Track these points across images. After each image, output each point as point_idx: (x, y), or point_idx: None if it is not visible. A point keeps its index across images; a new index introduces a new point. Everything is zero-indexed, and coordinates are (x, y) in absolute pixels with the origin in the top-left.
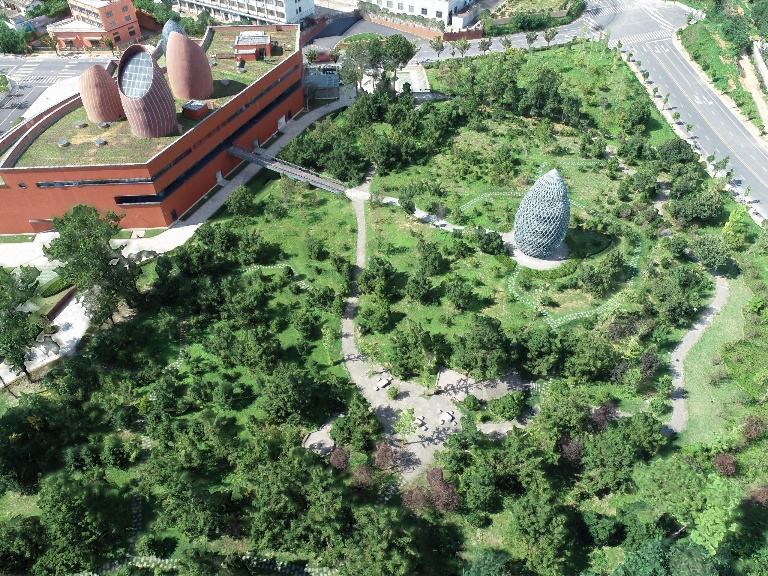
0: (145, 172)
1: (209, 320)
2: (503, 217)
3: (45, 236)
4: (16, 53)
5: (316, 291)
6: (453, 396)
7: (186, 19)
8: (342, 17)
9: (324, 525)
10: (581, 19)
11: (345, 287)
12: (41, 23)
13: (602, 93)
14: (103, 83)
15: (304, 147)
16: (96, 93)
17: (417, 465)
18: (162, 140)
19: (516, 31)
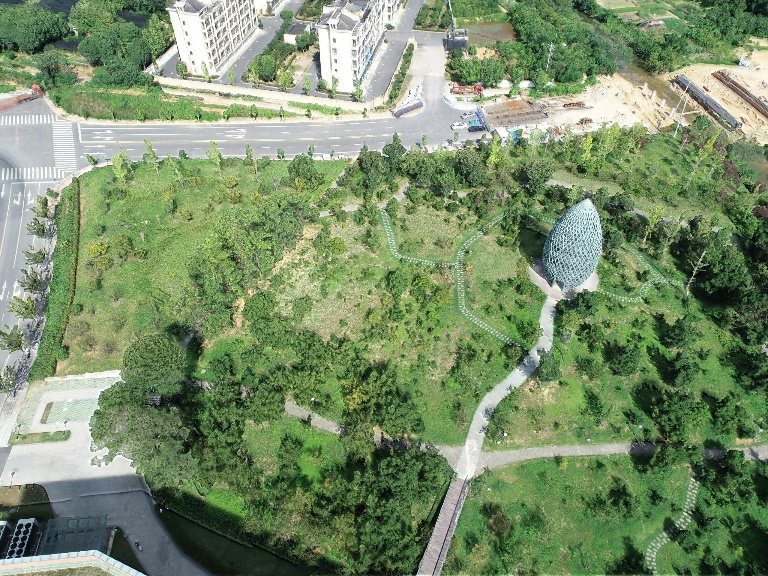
0: None
1: None
2: (513, 298)
3: None
4: None
5: None
6: None
7: None
8: None
9: None
10: None
11: None
12: None
13: (237, 188)
14: None
15: None
16: None
17: None
18: None
19: None
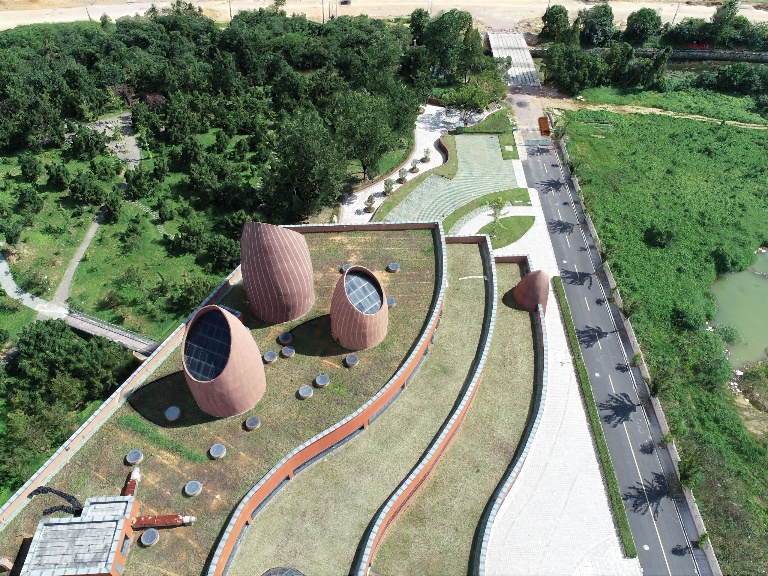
0: None
1: None
2: None
3: None
4: None
5: None
6: None
7: None
8: None
9: None
10: None
11: None
12: None
13: None
14: None
15: None
16: None
17: None
18: None
19: None
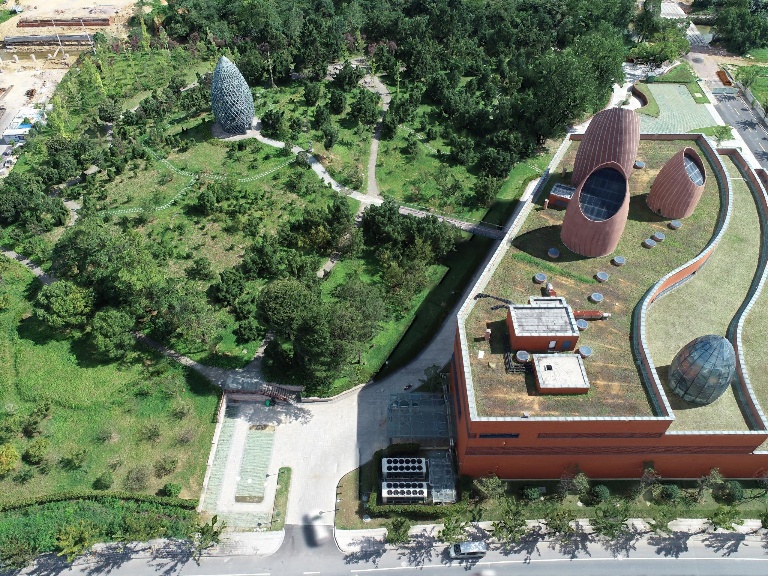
0: None
1: None
2: None
3: None
4: None
5: None
6: None
7: None
8: None
9: None
10: None
11: None
12: None
13: None
14: None
15: None
16: None
17: None
18: None
19: None
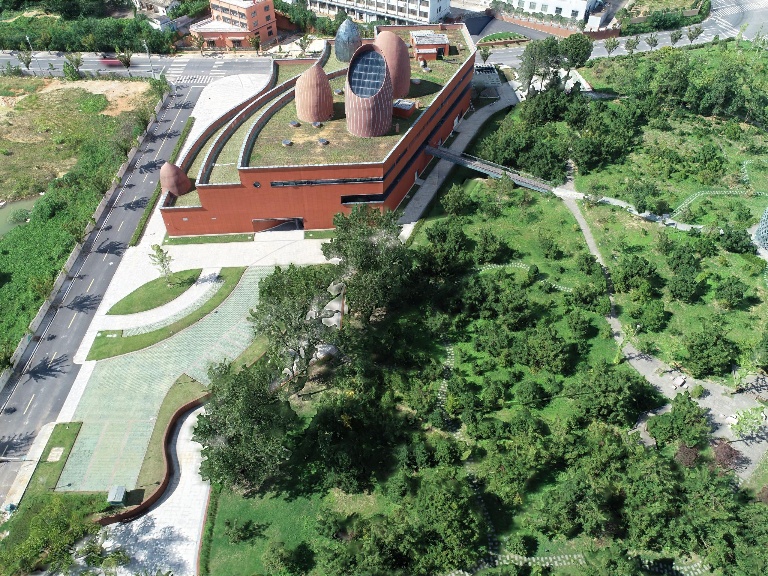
0: (379, 171)
1: (465, 319)
2: (729, 216)
3: (264, 235)
4: (160, 53)
5: (585, 290)
6: (758, 394)
7: (323, 19)
8: (474, 16)
9: (716, 523)
10: (711, 18)
11: (604, 286)
12: (182, 23)
13: None
14: (322, 82)
15: (502, 146)
16: (315, 92)
17: (748, 463)
18: (382, 139)
19: (651, 30)
